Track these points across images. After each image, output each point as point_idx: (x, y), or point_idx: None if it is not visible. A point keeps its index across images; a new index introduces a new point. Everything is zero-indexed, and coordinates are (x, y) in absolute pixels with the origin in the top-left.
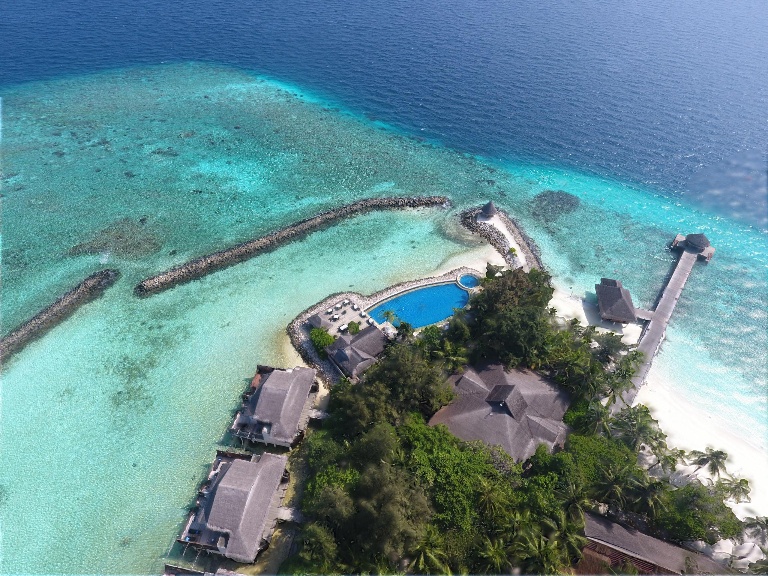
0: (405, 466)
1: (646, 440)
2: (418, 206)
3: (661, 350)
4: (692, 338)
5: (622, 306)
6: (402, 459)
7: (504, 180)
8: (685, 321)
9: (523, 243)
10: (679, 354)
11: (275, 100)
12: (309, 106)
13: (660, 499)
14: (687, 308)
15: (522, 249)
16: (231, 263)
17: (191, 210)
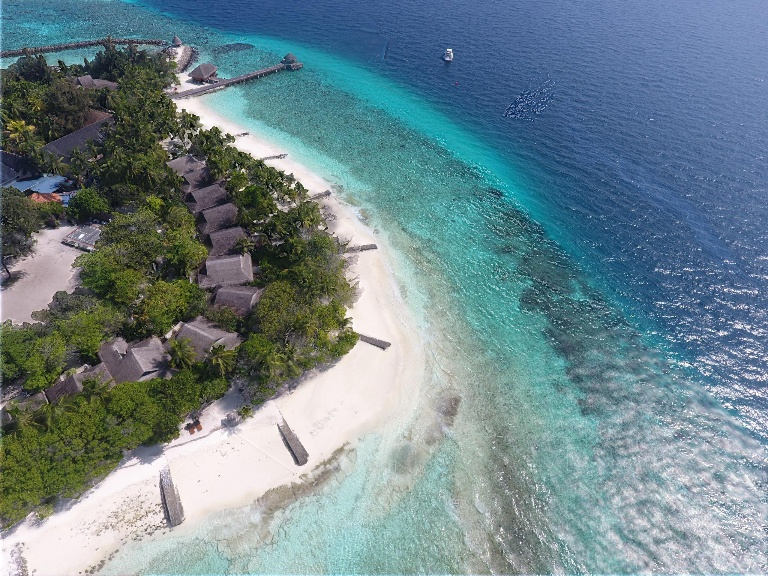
0: (5, 83)
1: (133, 91)
2: (143, 43)
3: (215, 92)
4: (240, 91)
5: (198, 70)
6: (5, 81)
7: (216, 38)
8: (246, 86)
9: (185, 56)
10: (224, 94)
11: (103, 0)
12: (124, 4)
13: (114, 100)
14: (255, 83)
15: (181, 57)
16: (6, 56)
17: (1, 39)
